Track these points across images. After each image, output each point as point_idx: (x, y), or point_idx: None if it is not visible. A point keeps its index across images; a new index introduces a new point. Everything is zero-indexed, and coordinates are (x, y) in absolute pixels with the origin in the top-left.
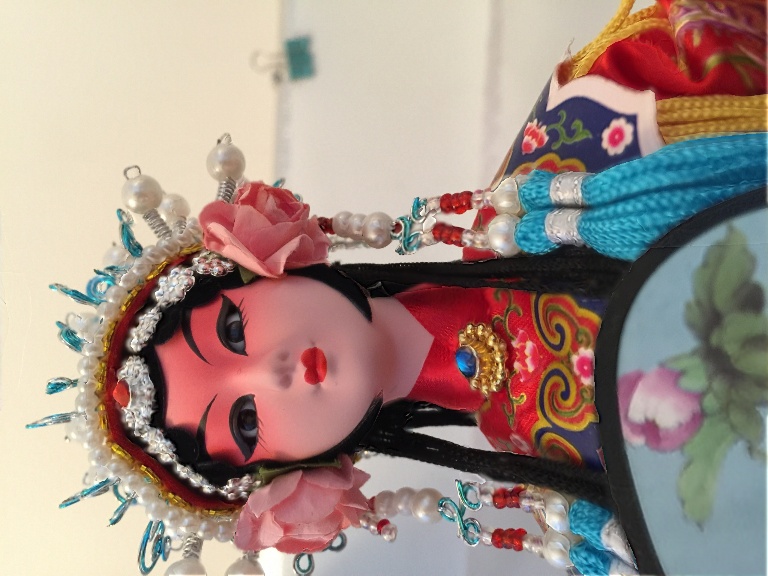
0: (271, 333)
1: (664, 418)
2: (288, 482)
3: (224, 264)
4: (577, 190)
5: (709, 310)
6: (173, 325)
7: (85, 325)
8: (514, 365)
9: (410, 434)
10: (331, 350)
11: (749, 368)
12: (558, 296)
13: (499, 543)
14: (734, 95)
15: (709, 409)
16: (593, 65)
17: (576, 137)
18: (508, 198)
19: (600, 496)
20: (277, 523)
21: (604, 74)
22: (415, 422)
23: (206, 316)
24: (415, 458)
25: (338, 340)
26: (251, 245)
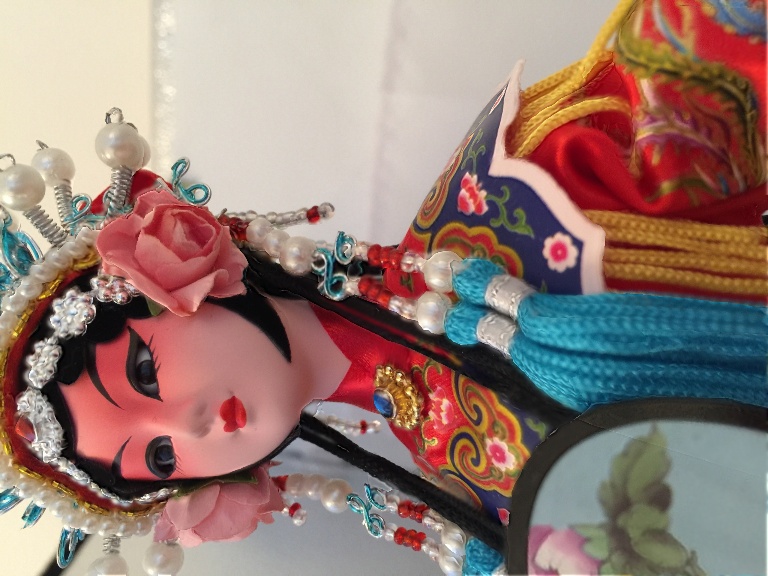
0: (187, 382)
1: (566, 571)
2: (206, 498)
3: (127, 287)
4: (513, 309)
5: (621, 494)
6: (77, 369)
7: None
8: (429, 413)
9: (322, 428)
10: (250, 400)
11: (645, 553)
12: (480, 385)
13: (400, 540)
14: (680, 222)
15: (605, 575)
16: (545, 141)
17: (517, 228)
18: (440, 276)
19: (495, 543)
20: (197, 535)
21: (556, 173)
22: (325, 400)
23: (113, 356)
24: None
25: (257, 390)
26: (158, 276)
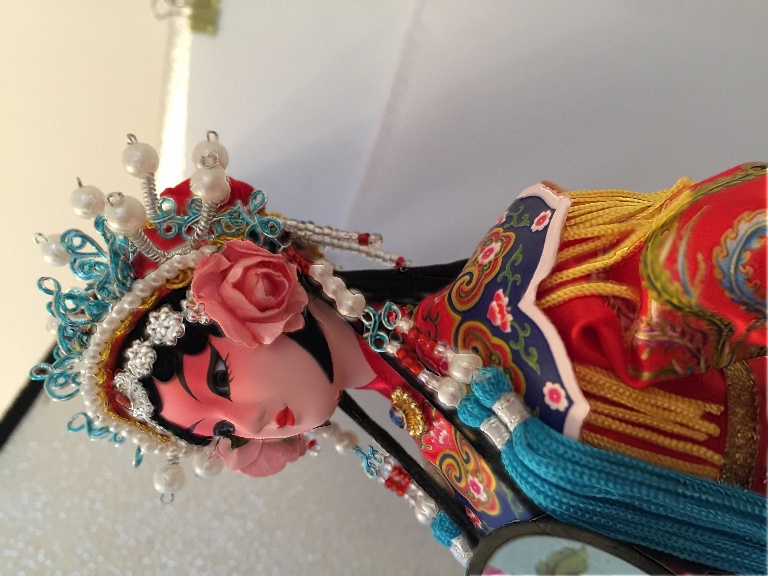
0: (253, 394)
1: None
2: (251, 448)
3: None
4: (511, 426)
5: (550, 571)
6: (169, 374)
7: (53, 249)
8: (430, 431)
9: (342, 395)
10: (299, 412)
11: None
12: None
13: None
14: (648, 394)
15: None
16: (568, 303)
17: (529, 361)
18: (463, 372)
19: (458, 523)
20: None
21: (569, 342)
22: None
23: (197, 365)
24: None
25: (306, 405)
26: (238, 313)
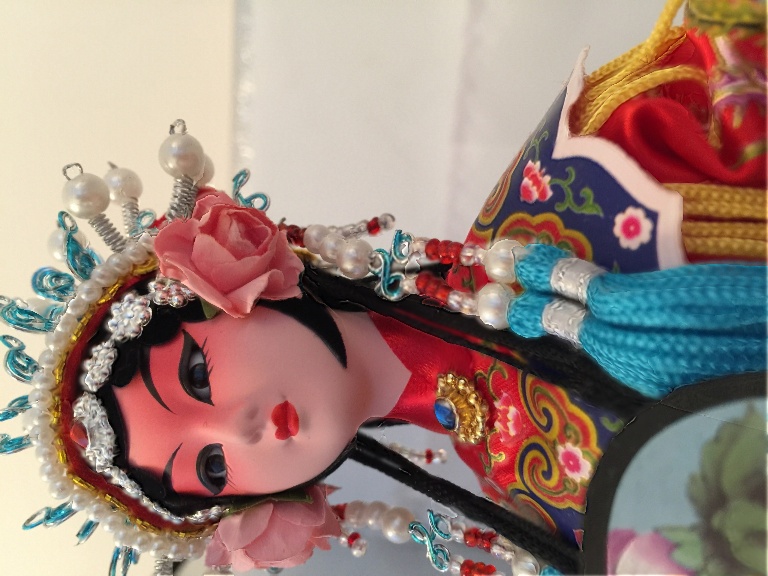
0: (238, 385)
1: None
2: (259, 517)
3: (184, 291)
4: (582, 290)
5: (715, 490)
6: (131, 370)
7: None
8: (495, 424)
9: (382, 450)
10: (303, 405)
11: (749, 561)
12: (549, 383)
13: (467, 574)
14: None
15: None
16: (612, 116)
17: (585, 208)
18: (502, 266)
19: (572, 571)
20: (248, 557)
21: (625, 144)
22: (387, 424)
23: (166, 358)
24: (387, 474)
25: (311, 394)
26: (213, 277)
